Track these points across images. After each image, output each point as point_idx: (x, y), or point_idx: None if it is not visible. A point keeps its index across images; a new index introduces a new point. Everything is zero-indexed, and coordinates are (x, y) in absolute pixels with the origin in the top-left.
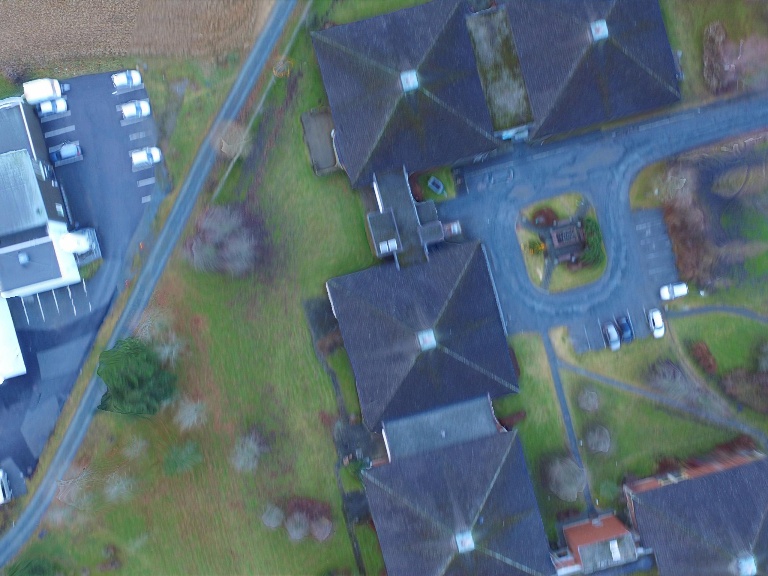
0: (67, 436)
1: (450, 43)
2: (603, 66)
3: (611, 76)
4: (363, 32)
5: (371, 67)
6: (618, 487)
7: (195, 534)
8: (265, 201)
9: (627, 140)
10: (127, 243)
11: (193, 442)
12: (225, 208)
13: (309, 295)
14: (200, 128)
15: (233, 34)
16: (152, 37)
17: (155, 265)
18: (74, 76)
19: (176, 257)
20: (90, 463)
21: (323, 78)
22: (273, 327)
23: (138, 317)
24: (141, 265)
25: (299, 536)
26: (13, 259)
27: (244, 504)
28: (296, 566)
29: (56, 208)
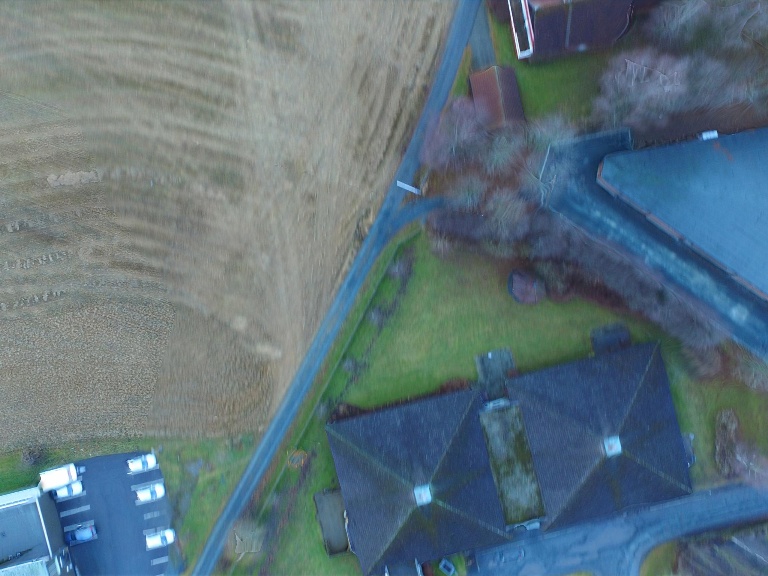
0: None
1: (463, 445)
2: (616, 473)
3: (623, 480)
4: (377, 430)
5: (385, 473)
6: None
7: None
8: None
9: (638, 520)
10: None
11: None
12: None
13: None
14: (214, 508)
15: (248, 417)
16: (167, 419)
17: None
18: (90, 457)
19: None
20: None
21: (337, 471)
22: None
23: None
24: None
25: None
26: None
27: None
28: None
29: None
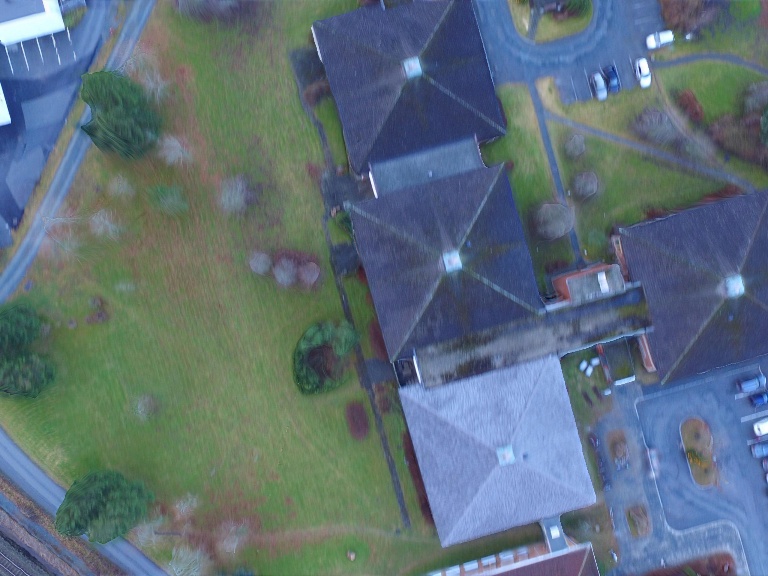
0: (53, 186)
1: None
2: None
3: None
4: None
5: None
6: (606, 237)
7: (183, 287)
8: None
9: None
10: None
11: (179, 186)
12: None
13: (295, 45)
14: None
15: None
16: None
17: (140, 13)
18: None
19: (161, 5)
20: (76, 212)
21: None
22: (259, 78)
23: None
24: (126, 13)
25: (287, 278)
26: None
27: (232, 257)
28: (284, 319)
29: None
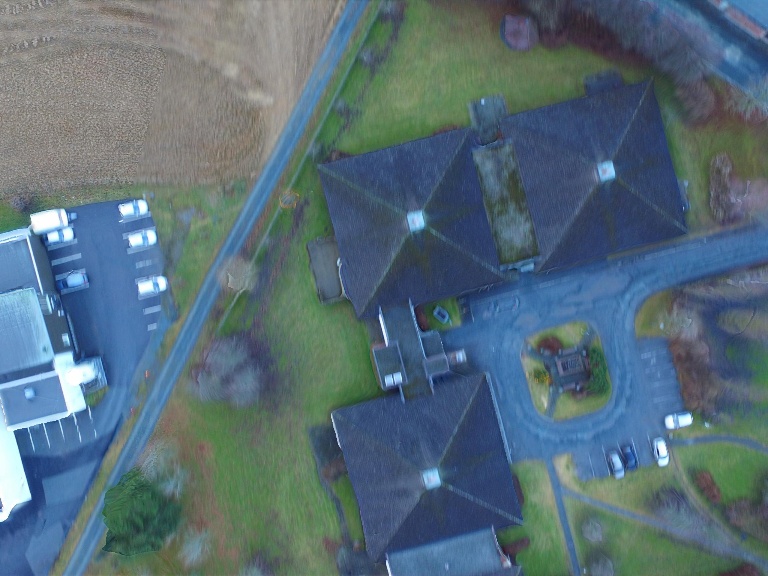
0: (72, 562)
1: (457, 179)
2: (610, 204)
3: (617, 213)
4: (370, 167)
5: (378, 204)
6: None
7: None
8: (271, 328)
9: (633, 269)
10: (133, 371)
11: (197, 572)
12: (231, 340)
13: (314, 422)
14: (206, 256)
15: (240, 163)
16: (159, 166)
17: (160, 392)
18: (81, 204)
19: (181, 385)
20: None
21: (329, 211)
22: (278, 454)
23: (143, 444)
24: (146, 392)
25: None
26: (19, 393)
27: None
28: None
29: (62, 339)
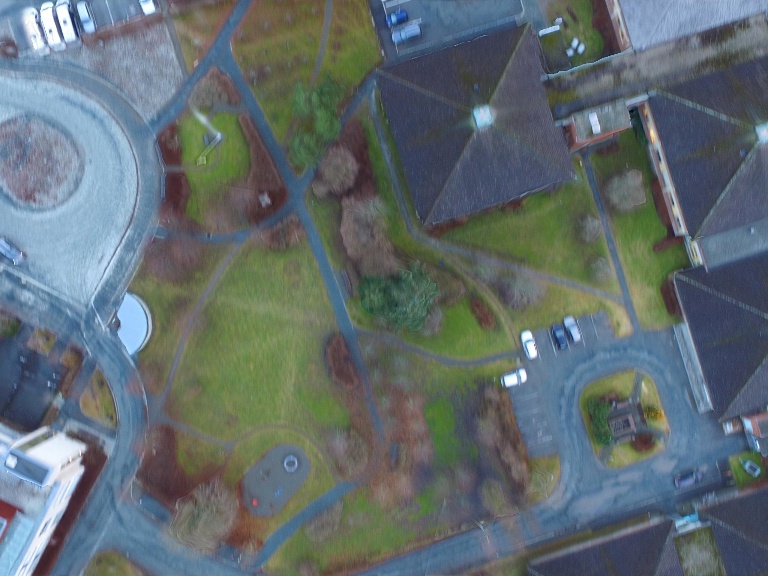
0: None
1: None
2: None
3: None
4: None
5: None
6: None
7: None
8: None
9: (565, 522)
10: None
11: None
12: None
13: None
14: None
15: None
16: None
17: None
18: None
19: None
20: None
21: None
22: None
23: None
24: None
25: None
26: None
27: None
28: None
29: None
